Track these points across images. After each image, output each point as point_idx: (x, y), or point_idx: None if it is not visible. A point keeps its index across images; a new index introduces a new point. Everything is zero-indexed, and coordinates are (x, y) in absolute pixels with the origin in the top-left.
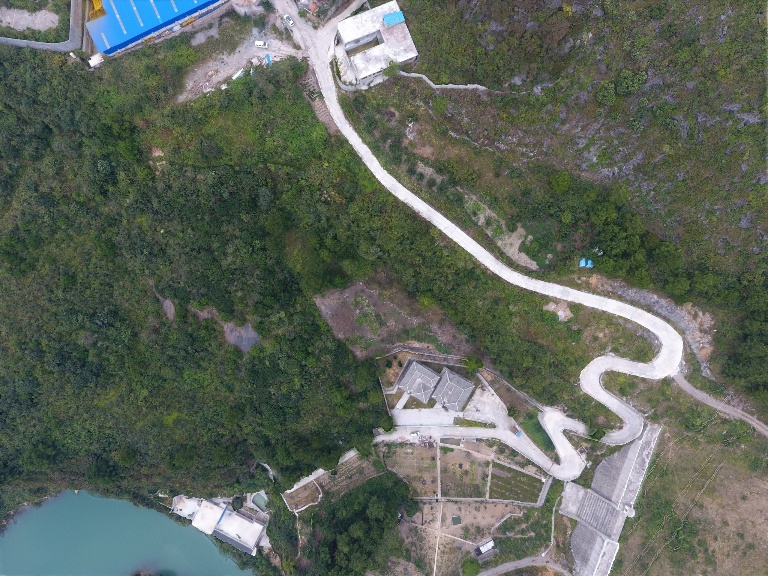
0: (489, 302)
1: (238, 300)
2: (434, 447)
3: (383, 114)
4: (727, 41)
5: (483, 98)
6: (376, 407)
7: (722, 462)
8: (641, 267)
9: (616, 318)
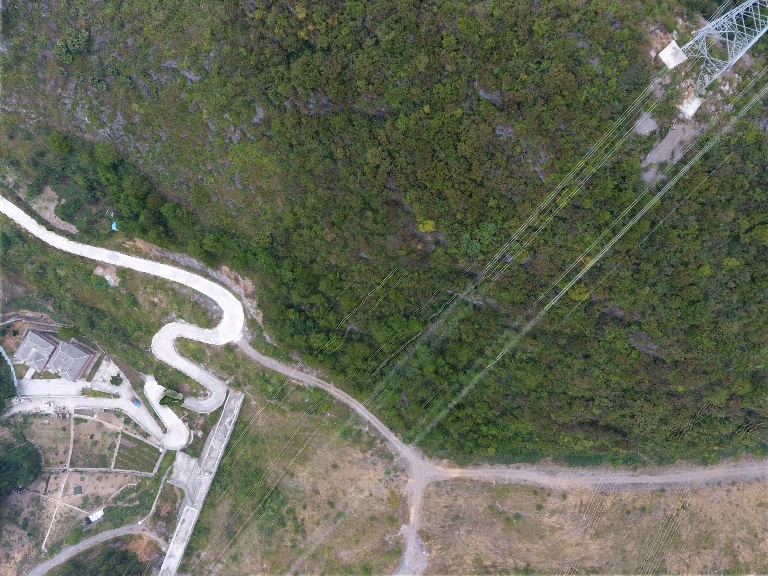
0: (36, 266)
1: None
2: (68, 418)
3: None
4: None
5: None
6: None
7: (314, 431)
8: (152, 229)
9: (170, 283)
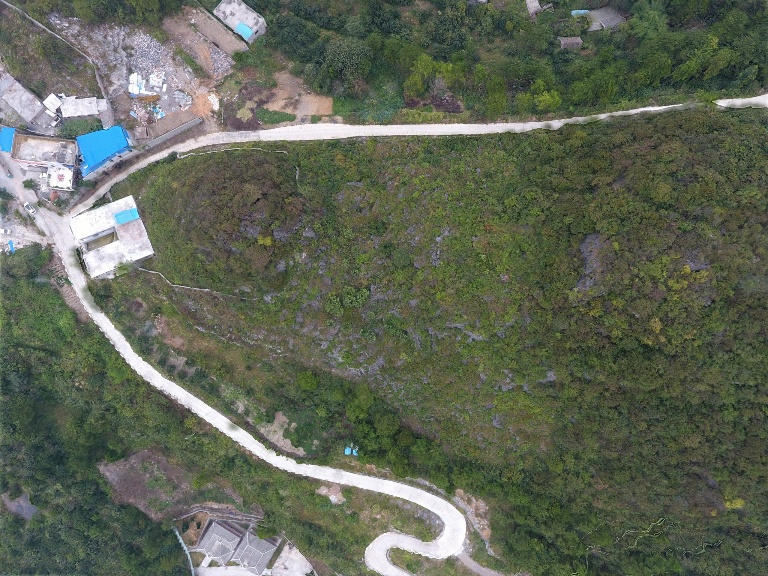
0: (257, 487)
1: (7, 476)
2: None
3: (131, 304)
4: (440, 266)
5: (219, 299)
6: (177, 568)
7: None
8: (398, 463)
9: (393, 499)
